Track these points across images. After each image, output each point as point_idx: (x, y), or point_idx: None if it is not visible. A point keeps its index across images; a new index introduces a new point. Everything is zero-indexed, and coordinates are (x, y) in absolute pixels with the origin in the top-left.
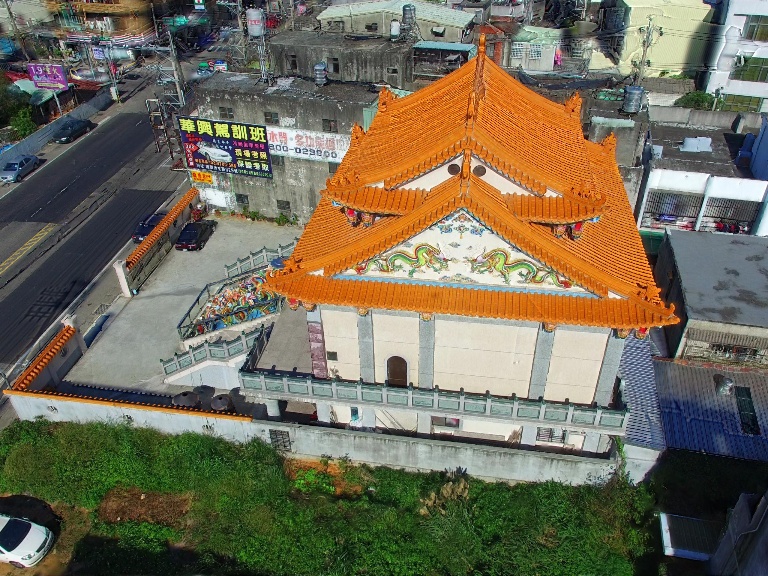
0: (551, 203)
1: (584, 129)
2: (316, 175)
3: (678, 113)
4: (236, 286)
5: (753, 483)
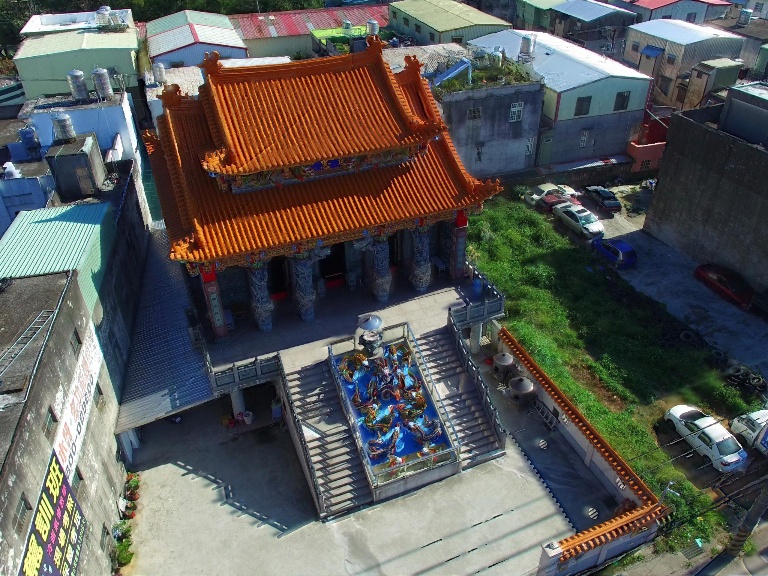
0: None
1: None
2: (97, 436)
3: None
4: (343, 470)
5: None
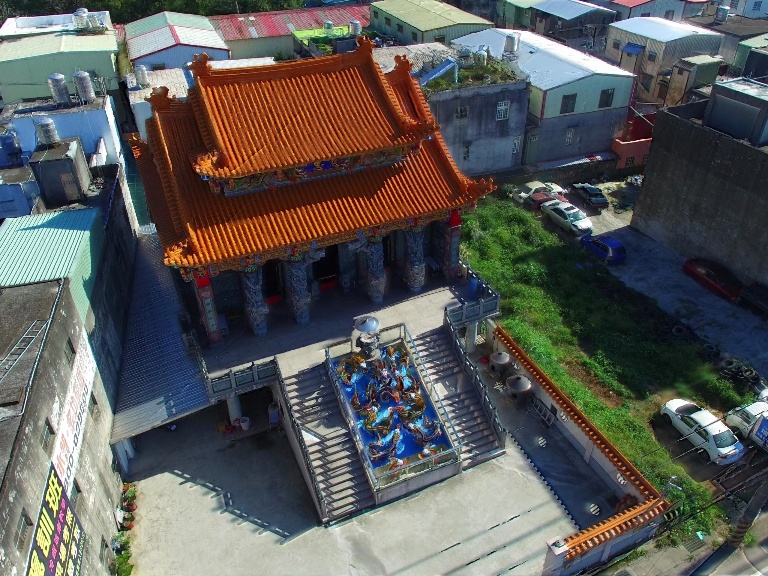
0: None
1: None
2: (93, 447)
3: None
4: (344, 474)
5: None
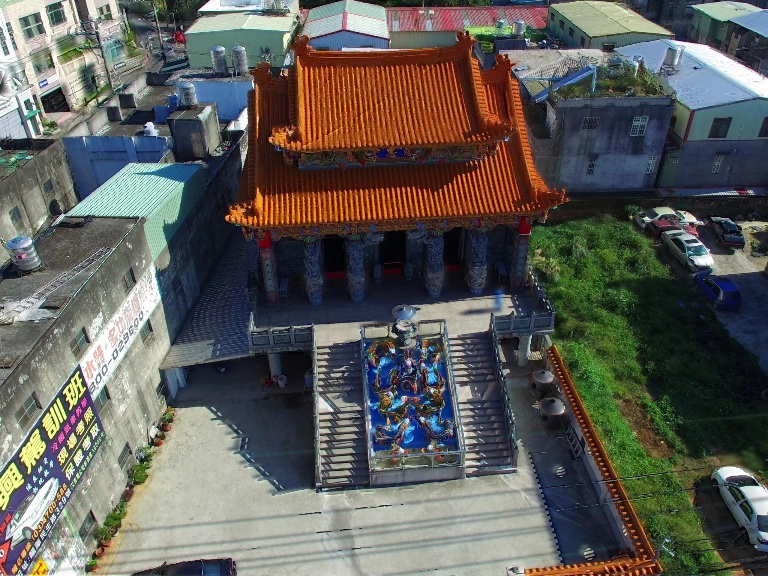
0: None
1: (45, 191)
2: (136, 365)
3: (83, 130)
4: (348, 448)
5: None
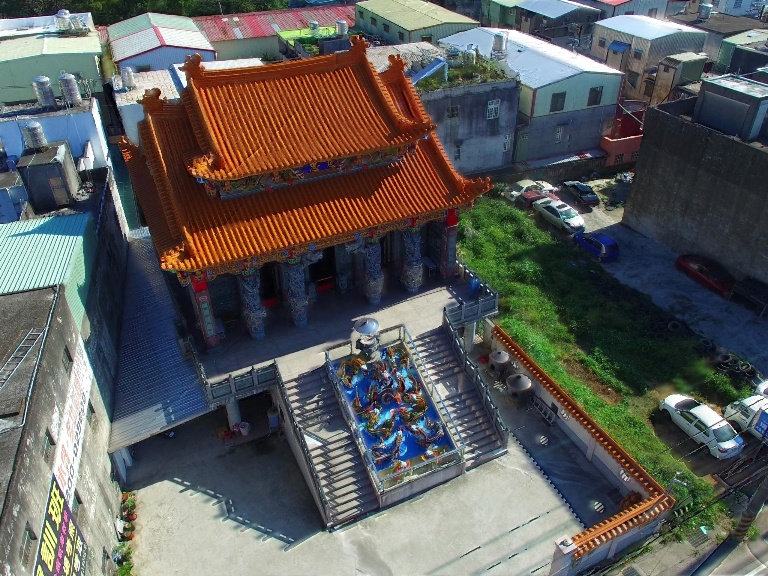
0: None
1: None
2: (92, 456)
3: None
4: (348, 477)
5: None
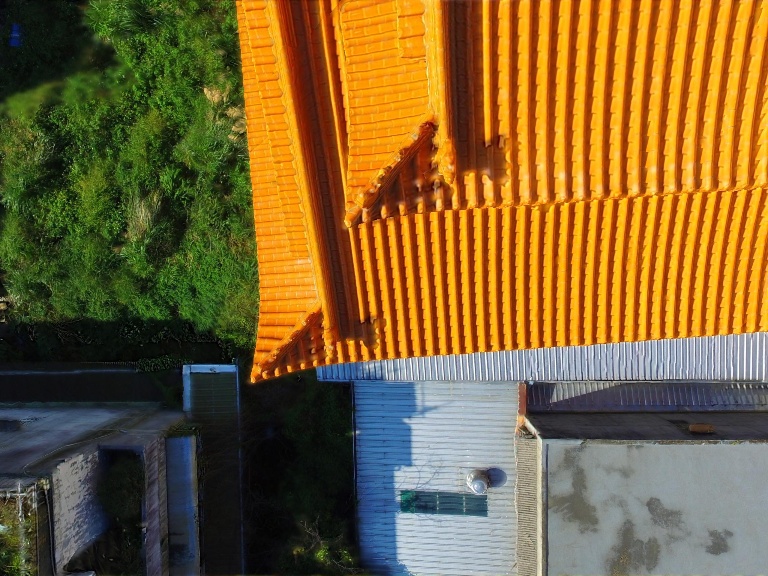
0: (405, 85)
1: None
2: None
3: None
4: None
5: (295, 480)
